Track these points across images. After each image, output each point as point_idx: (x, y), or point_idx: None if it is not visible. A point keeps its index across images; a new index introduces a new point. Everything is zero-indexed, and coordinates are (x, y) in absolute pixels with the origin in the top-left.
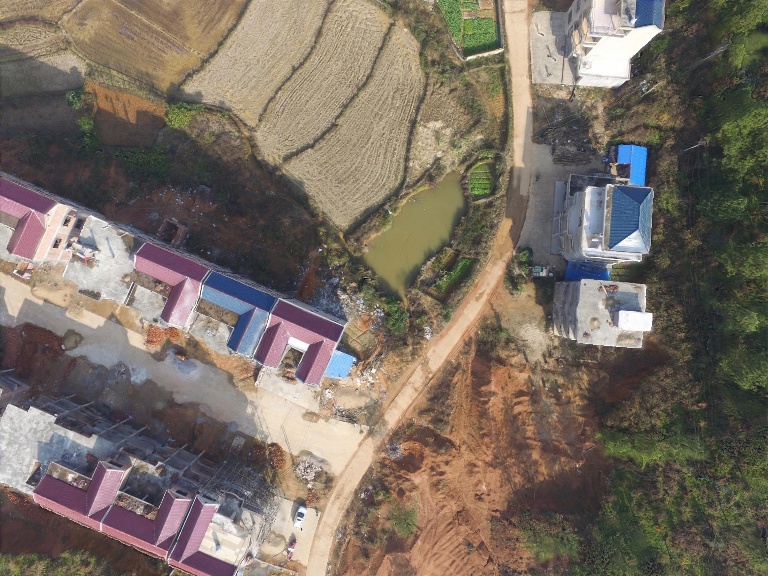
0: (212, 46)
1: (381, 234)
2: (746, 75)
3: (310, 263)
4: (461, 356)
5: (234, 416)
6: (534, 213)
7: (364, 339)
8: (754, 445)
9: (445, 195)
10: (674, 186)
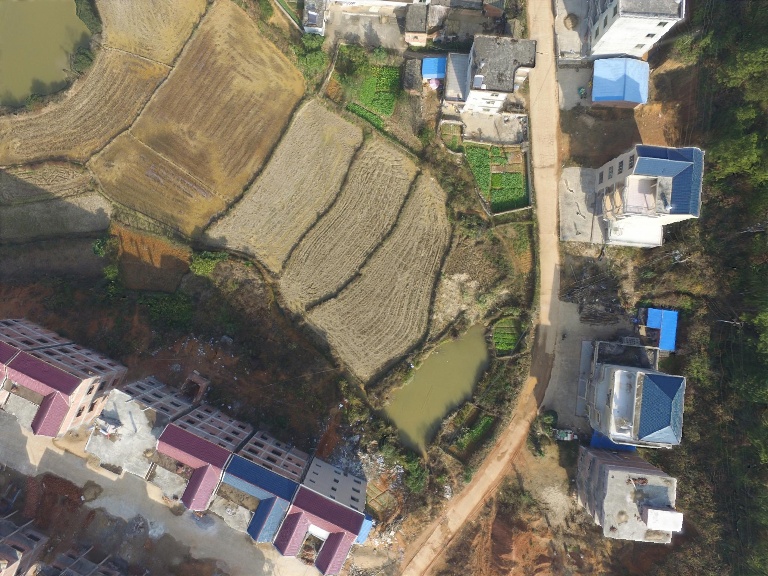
0: (237, 190)
1: (403, 388)
2: None
3: (331, 420)
4: (481, 517)
5: (251, 573)
6: (559, 372)
7: (383, 499)
8: None
9: (468, 348)
10: (705, 356)
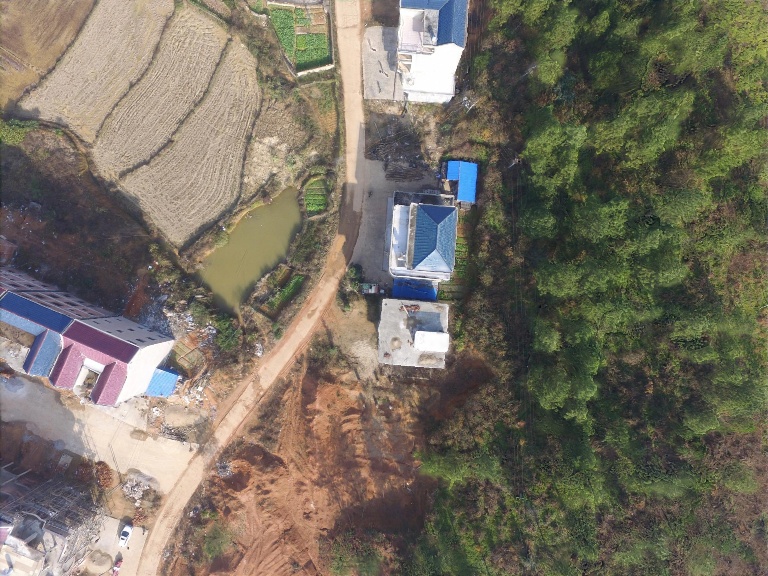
0: (51, 62)
1: (215, 251)
2: (561, 92)
3: (139, 280)
4: (292, 373)
5: (61, 434)
6: (367, 229)
7: (192, 357)
8: (570, 464)
9: (282, 211)
10: (499, 203)
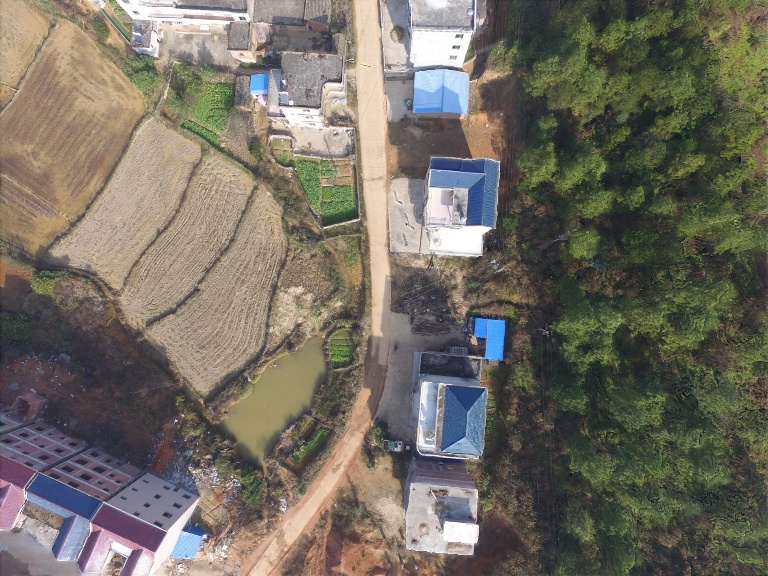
0: (80, 209)
1: (240, 402)
2: (593, 261)
3: (165, 435)
4: (317, 530)
5: None
6: (392, 383)
7: (217, 513)
8: None
9: (307, 360)
10: (529, 365)
